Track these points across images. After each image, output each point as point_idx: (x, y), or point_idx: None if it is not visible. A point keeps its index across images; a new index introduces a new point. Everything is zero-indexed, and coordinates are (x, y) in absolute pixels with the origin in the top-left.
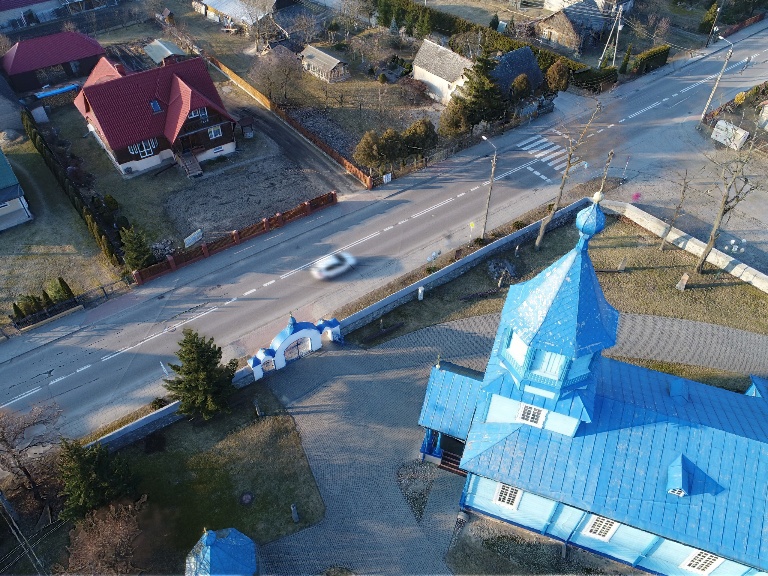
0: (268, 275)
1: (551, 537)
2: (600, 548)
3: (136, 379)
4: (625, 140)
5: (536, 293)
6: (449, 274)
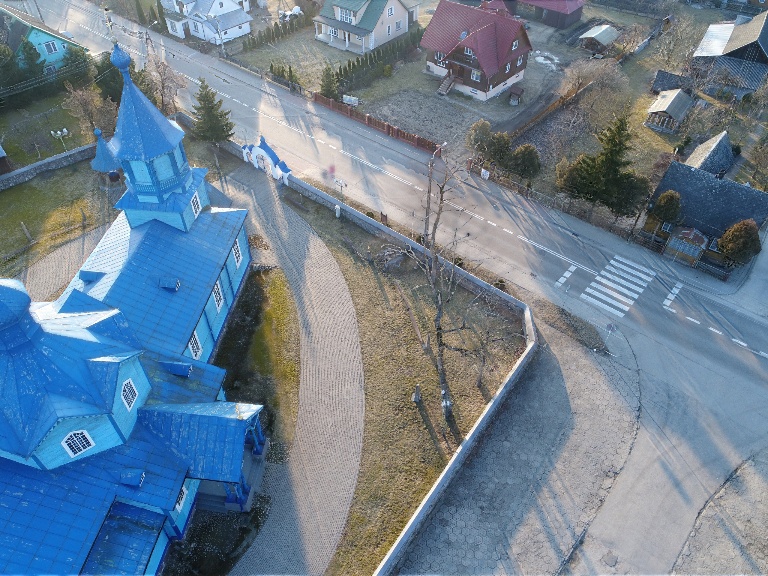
0: (341, 145)
1: None
2: None
3: (240, 122)
4: (711, 357)
5: None
6: (366, 223)
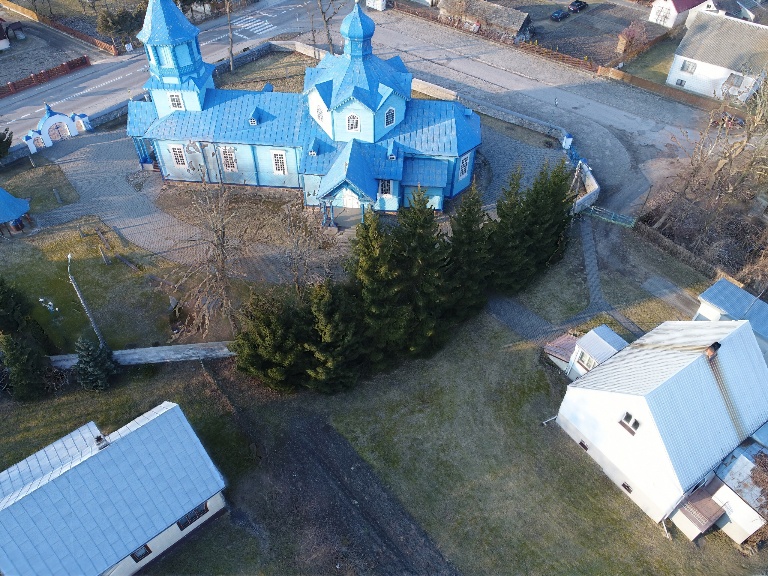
0: (39, 106)
1: (214, 183)
2: (239, 180)
3: None
4: None
5: (146, 16)
6: None
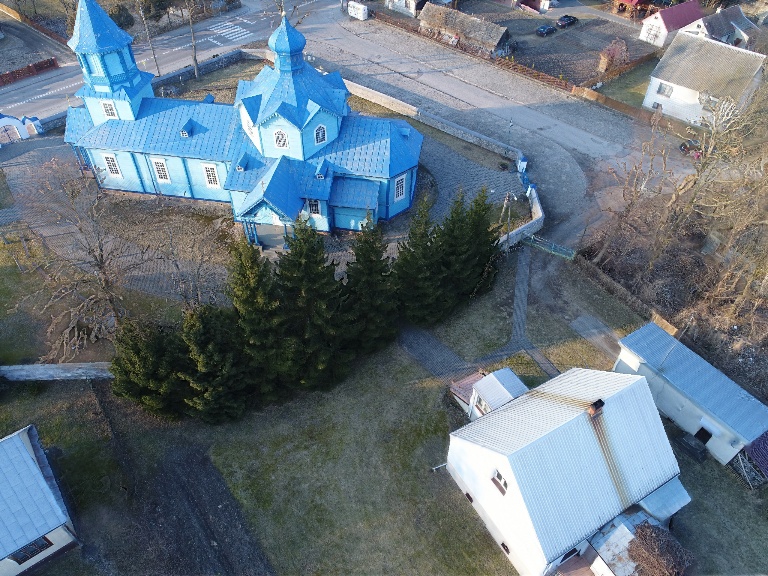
0: None
1: (149, 194)
2: (173, 192)
3: None
4: None
5: None
6: None
